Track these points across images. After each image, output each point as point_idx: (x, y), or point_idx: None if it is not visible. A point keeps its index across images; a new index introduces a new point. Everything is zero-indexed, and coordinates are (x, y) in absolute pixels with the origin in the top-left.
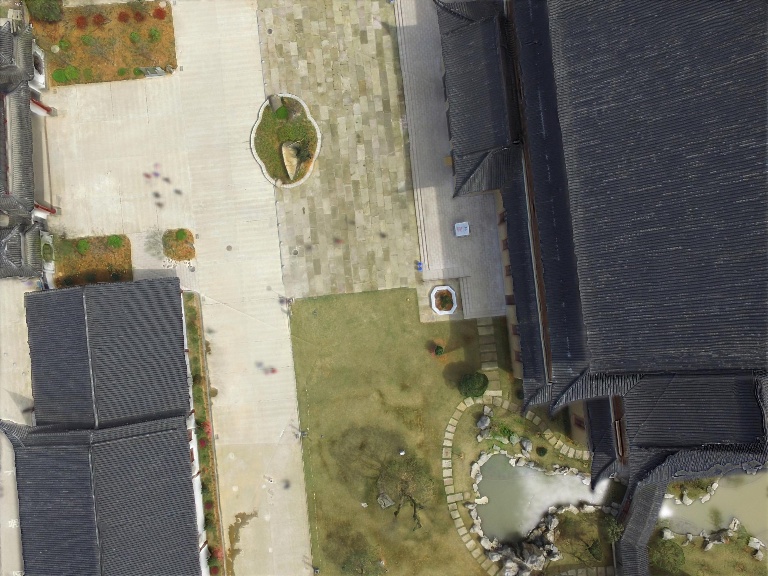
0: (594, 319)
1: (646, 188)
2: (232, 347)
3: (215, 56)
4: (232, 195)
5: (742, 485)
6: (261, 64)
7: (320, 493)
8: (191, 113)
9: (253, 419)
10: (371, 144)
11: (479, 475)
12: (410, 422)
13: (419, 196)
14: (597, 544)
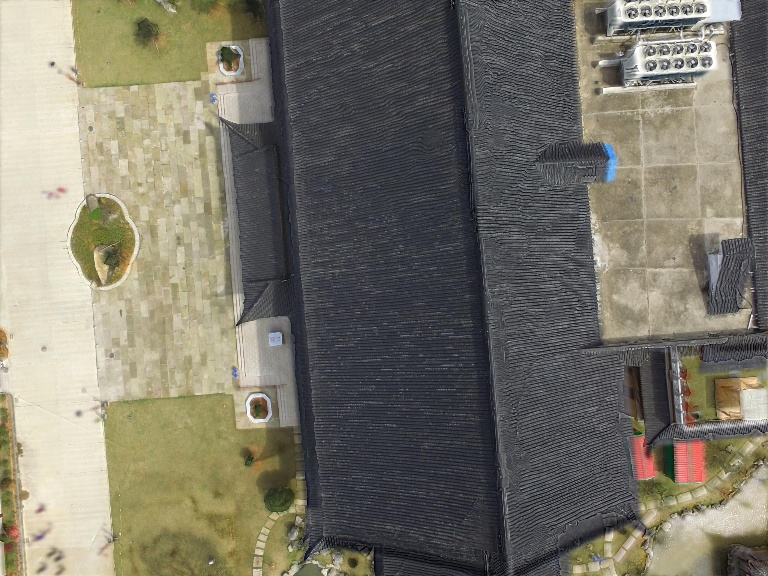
0: (328, 482)
1: (369, 360)
2: (45, 450)
3: (34, 153)
4: (48, 295)
5: None
6: (81, 162)
7: None
8: (8, 211)
9: (65, 523)
10: (191, 247)
11: None
12: (222, 530)
13: (238, 301)
14: None
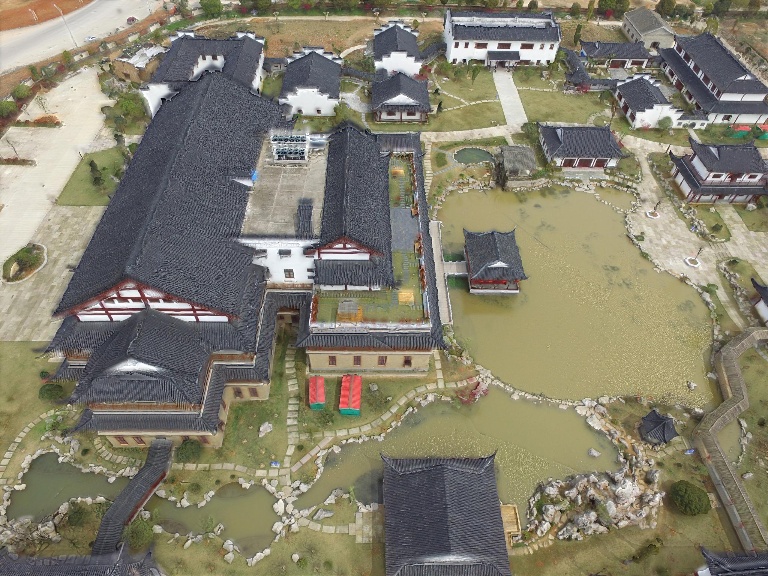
0: None
1: None
2: None
3: (12, 227)
4: None
5: (236, 497)
6: (35, 232)
7: None
8: None
9: None
10: None
11: (26, 463)
12: None
13: None
14: (77, 512)
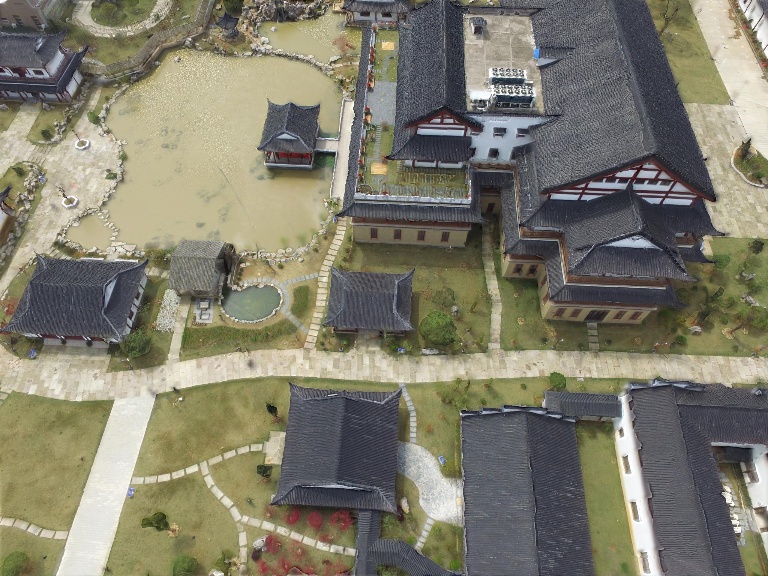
0: None
1: None
2: (759, 92)
3: None
4: None
5: None
6: None
7: (699, 41)
8: None
9: (740, 67)
10: None
11: None
12: None
13: None
14: None
